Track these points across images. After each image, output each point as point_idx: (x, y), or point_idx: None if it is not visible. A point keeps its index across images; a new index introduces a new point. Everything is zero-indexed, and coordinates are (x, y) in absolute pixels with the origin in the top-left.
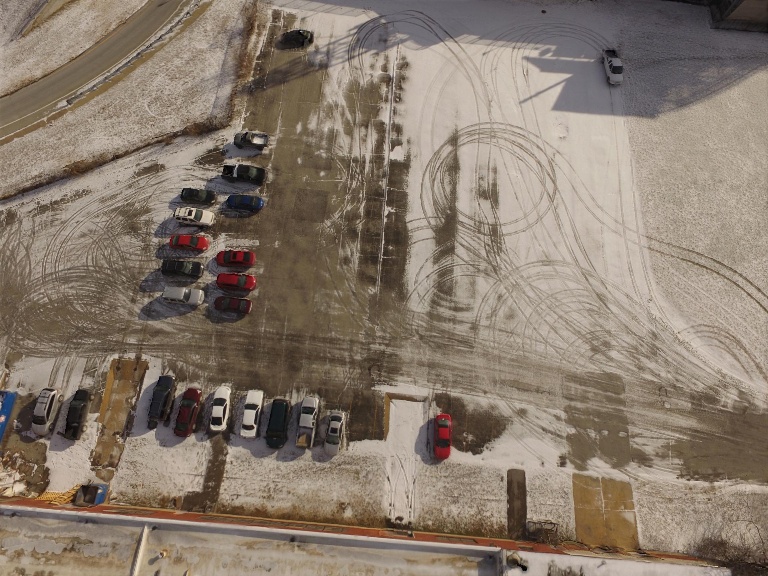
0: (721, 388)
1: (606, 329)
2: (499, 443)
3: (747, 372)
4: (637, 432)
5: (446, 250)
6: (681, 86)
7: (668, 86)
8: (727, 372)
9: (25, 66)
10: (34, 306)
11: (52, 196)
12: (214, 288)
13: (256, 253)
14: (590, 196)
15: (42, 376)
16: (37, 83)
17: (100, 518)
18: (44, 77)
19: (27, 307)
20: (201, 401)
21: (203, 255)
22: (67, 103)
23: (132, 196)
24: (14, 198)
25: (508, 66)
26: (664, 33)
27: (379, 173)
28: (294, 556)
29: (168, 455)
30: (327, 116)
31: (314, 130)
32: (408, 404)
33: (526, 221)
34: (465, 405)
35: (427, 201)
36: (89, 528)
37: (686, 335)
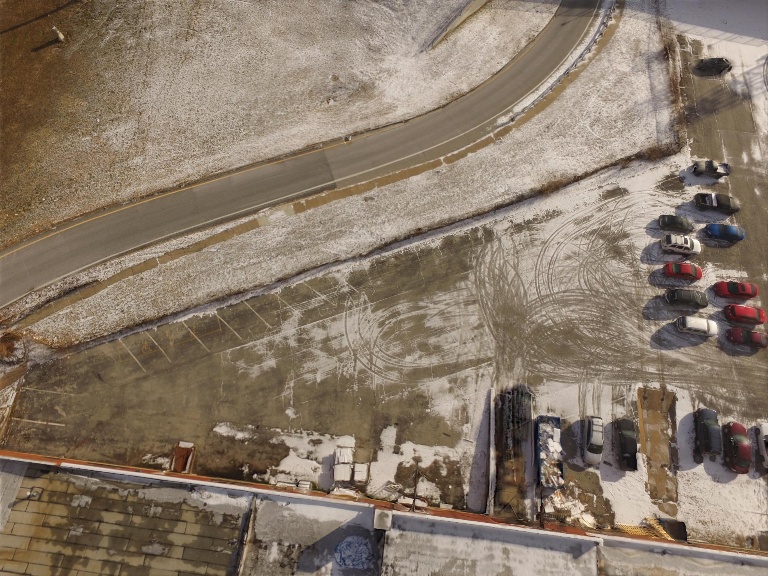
0: None
1: None
2: None
3: None
4: None
5: None
6: None
7: None
8: None
9: (447, 79)
10: (540, 328)
11: (523, 215)
12: (718, 319)
13: None
14: None
15: (570, 402)
16: (466, 97)
17: (757, 560)
18: (471, 91)
19: (533, 329)
20: None
21: (696, 284)
22: (509, 120)
23: (605, 219)
24: (486, 215)
25: None
26: None
27: None
28: None
29: (726, 491)
30: None
31: (760, 161)
32: None
33: None
34: None
35: None
36: (748, 570)
37: None
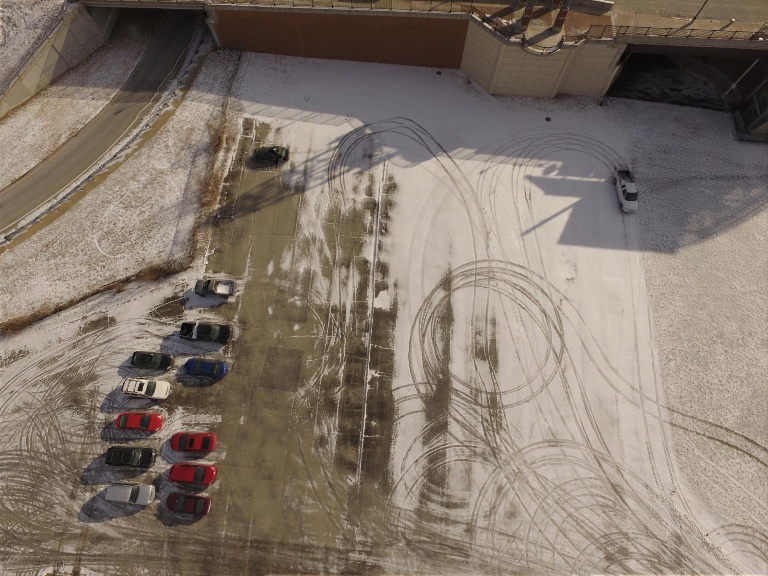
0: None
1: (623, 531)
2: None
3: None
4: None
5: (438, 427)
6: (703, 212)
7: (688, 212)
8: None
9: None
10: None
11: None
12: (168, 479)
13: (217, 433)
14: (602, 355)
15: None
16: None
17: None
18: None
19: None
20: None
21: (156, 436)
22: (5, 239)
23: (76, 359)
24: None
25: (508, 188)
26: (682, 146)
27: (361, 326)
28: None
29: None
30: (303, 253)
31: (288, 271)
32: None
33: (529, 388)
34: None
35: (416, 362)
36: None
37: (715, 538)
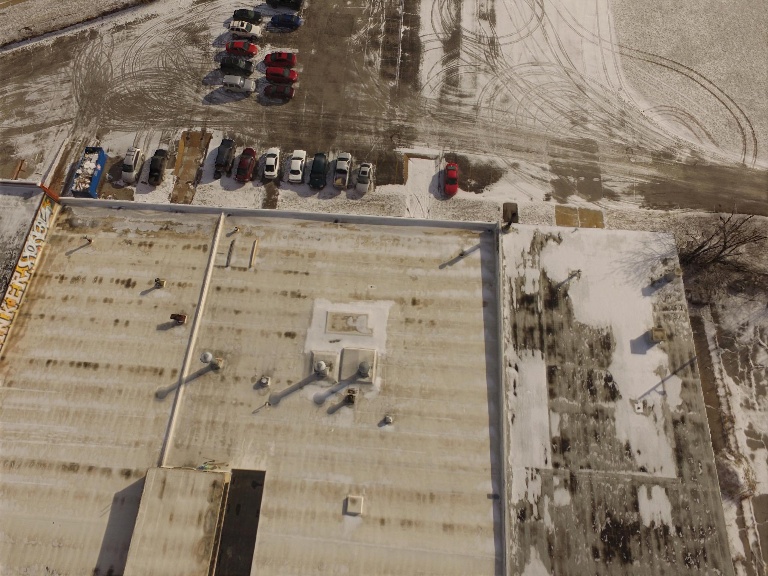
0: (677, 148)
1: (584, 109)
2: (496, 186)
3: (698, 138)
4: (608, 178)
5: (453, 55)
6: None
7: None
8: (682, 138)
9: None
10: (117, 96)
11: (126, 19)
12: (263, 82)
13: (296, 57)
14: (572, 18)
15: (127, 144)
16: None
17: (187, 209)
18: None
19: (111, 97)
20: (256, 159)
21: (253, 59)
22: None
23: (192, 18)
24: (95, 20)
25: None
26: None
27: (396, 2)
28: (338, 231)
29: (231, 196)
30: None
31: None
32: (423, 161)
33: (519, 35)
34: (469, 161)
35: (436, 22)
36: (179, 216)
37: (649, 113)
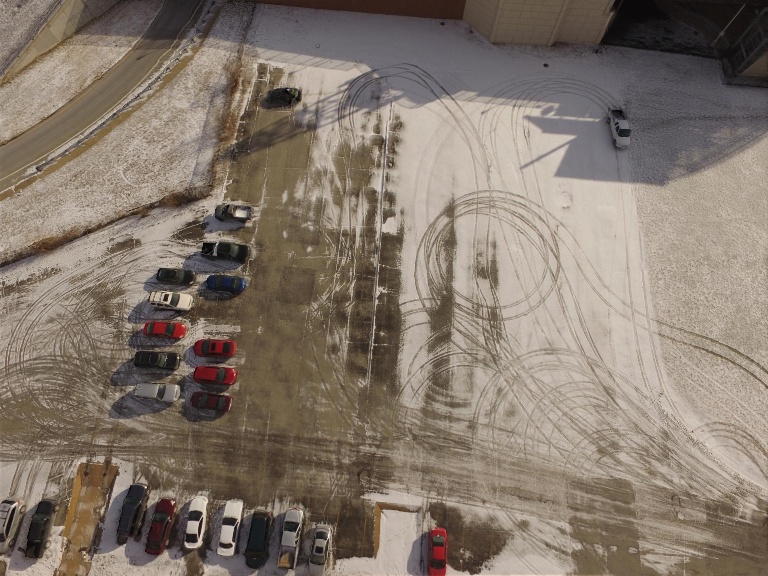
0: (739, 496)
1: (614, 428)
2: (499, 561)
3: (766, 477)
4: (648, 548)
5: (442, 337)
6: (692, 149)
7: (678, 149)
8: (745, 477)
9: None
10: None
11: (18, 275)
12: (191, 381)
13: (237, 341)
14: (596, 274)
15: (3, 483)
16: (5, 146)
17: None
18: (13, 139)
19: None
20: (175, 512)
21: (180, 343)
22: (37, 170)
23: (104, 275)
24: None
25: (508, 127)
26: (673, 89)
27: (370, 248)
28: None
29: (138, 575)
30: (315, 184)
31: (301, 199)
32: (400, 515)
33: (528, 303)
34: (462, 516)
35: (422, 280)
36: None
37: (700, 434)
